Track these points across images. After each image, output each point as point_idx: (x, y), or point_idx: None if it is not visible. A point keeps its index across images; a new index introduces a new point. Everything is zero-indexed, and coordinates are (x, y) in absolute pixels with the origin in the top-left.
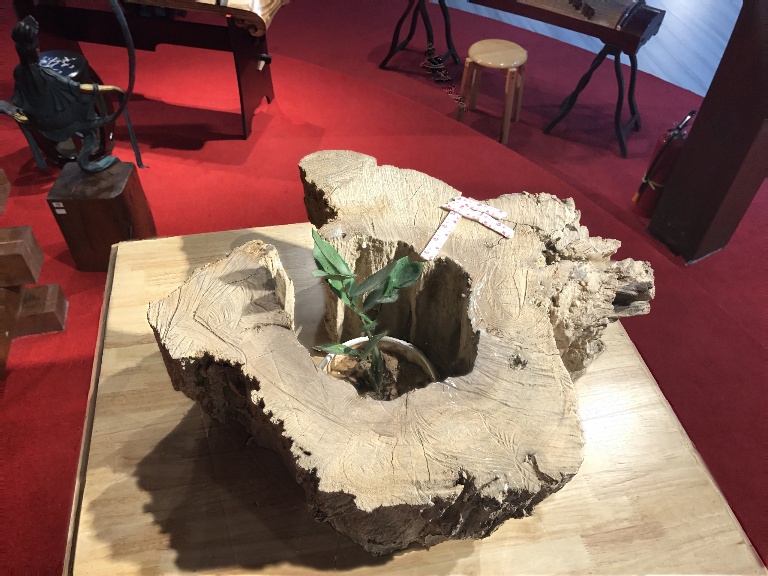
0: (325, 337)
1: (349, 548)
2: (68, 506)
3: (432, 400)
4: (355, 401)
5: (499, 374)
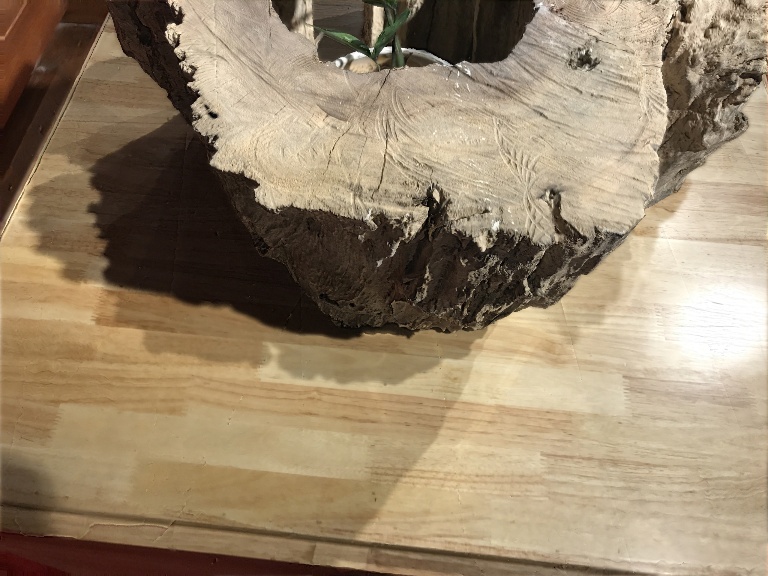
0: None
1: (310, 310)
2: (18, 190)
3: (425, 85)
4: (308, 63)
5: (547, 70)
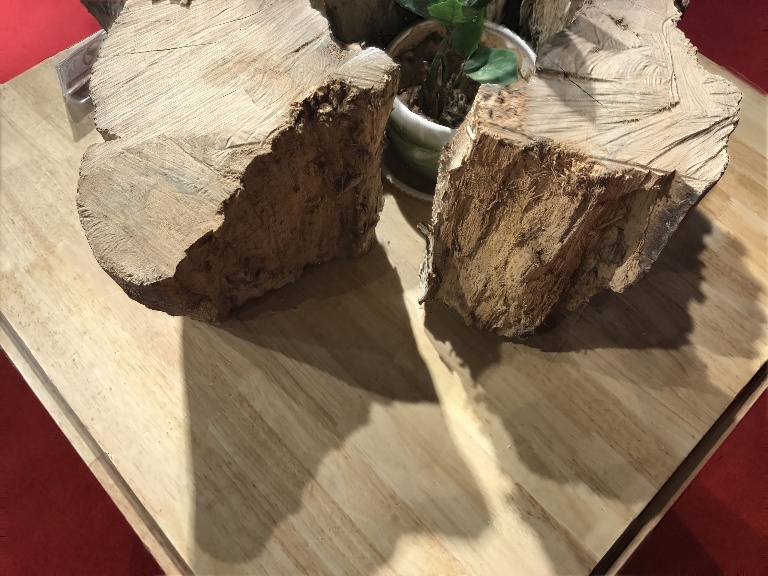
0: (355, 275)
1: None
2: (762, 404)
3: None
4: None
5: None
